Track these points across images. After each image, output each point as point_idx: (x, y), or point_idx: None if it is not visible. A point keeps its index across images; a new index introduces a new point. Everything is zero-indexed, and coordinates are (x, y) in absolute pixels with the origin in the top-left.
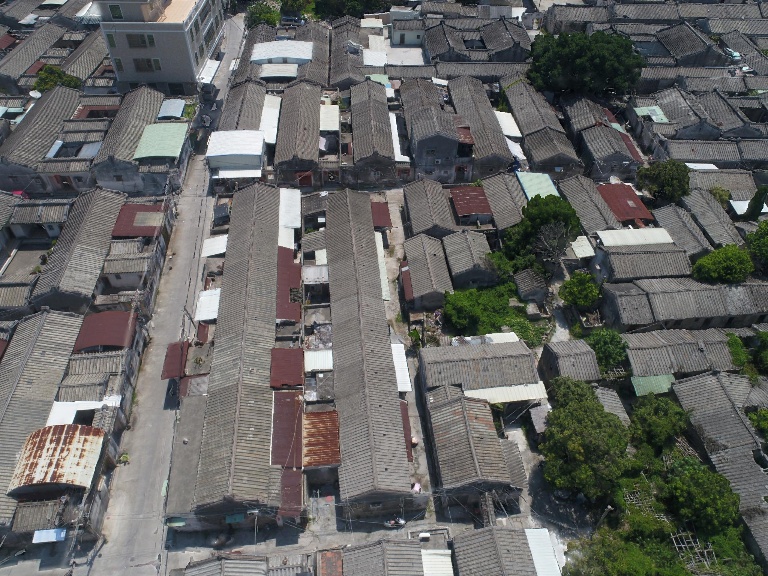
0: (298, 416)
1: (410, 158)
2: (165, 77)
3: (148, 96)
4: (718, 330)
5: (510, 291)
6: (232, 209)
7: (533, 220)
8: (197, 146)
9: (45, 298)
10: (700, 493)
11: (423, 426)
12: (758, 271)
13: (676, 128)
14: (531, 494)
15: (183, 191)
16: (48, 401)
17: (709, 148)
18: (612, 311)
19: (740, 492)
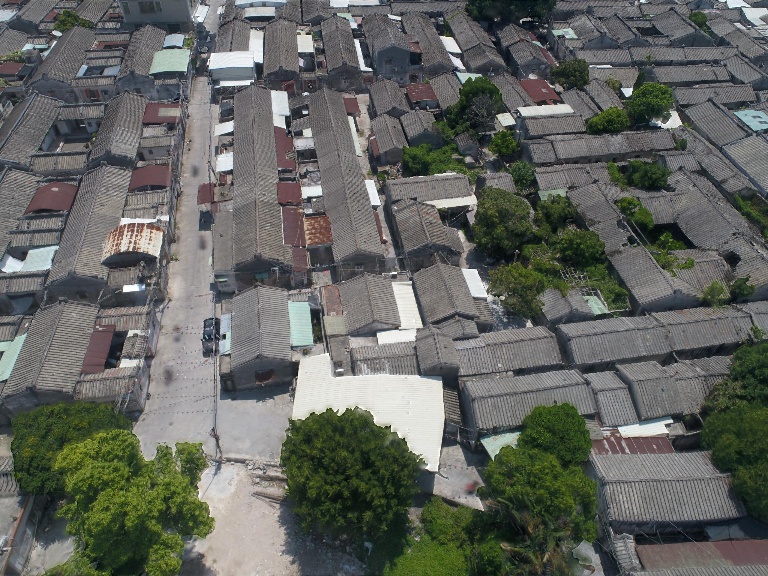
0: (300, 220)
1: (373, 69)
2: (165, 18)
3: (153, 32)
4: (602, 163)
5: (452, 149)
6: (234, 104)
7: (467, 97)
8: (197, 71)
9: (100, 161)
10: (577, 239)
11: (391, 232)
12: (633, 125)
13: (583, 42)
14: (468, 264)
15: (190, 101)
16: (117, 217)
17: (607, 54)
18: (527, 157)
19: (607, 244)
